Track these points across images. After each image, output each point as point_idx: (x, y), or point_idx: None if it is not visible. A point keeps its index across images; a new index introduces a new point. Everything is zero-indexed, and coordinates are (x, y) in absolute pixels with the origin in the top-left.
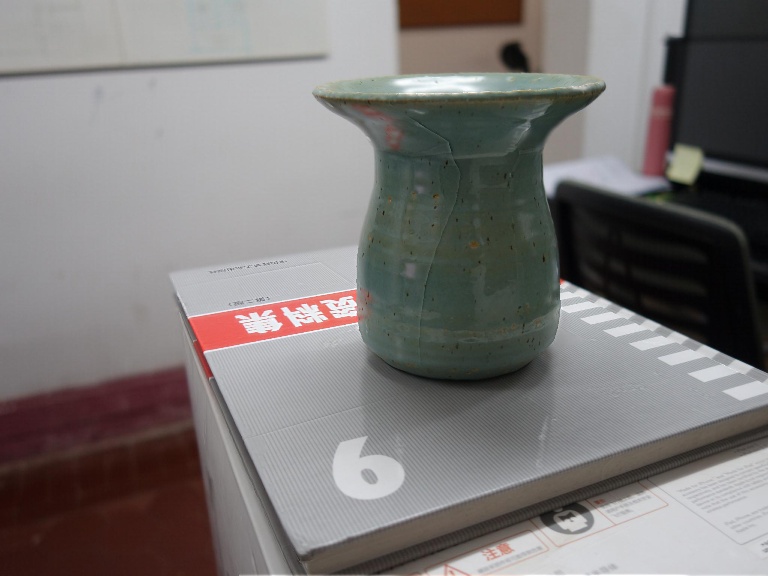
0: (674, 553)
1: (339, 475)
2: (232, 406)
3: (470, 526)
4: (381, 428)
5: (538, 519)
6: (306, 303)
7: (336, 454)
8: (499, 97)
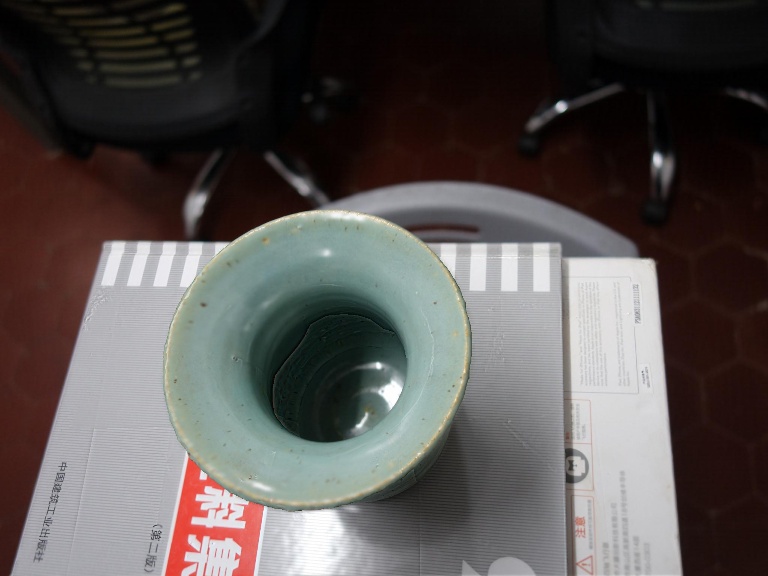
0: (628, 433)
1: None
2: None
3: None
4: (458, 545)
5: None
6: (196, 494)
7: None
8: (463, 394)
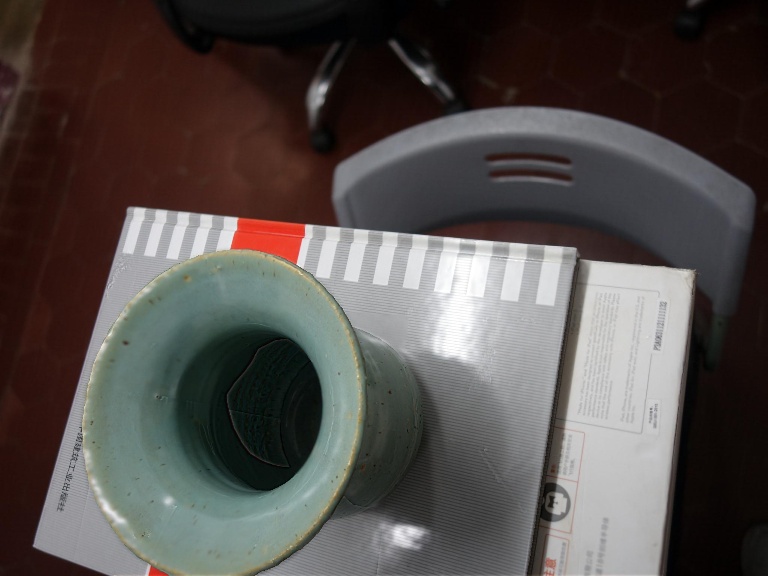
0: (621, 477)
1: None
2: None
3: None
4: (415, 571)
5: (542, 521)
6: None
7: None
8: (346, 487)
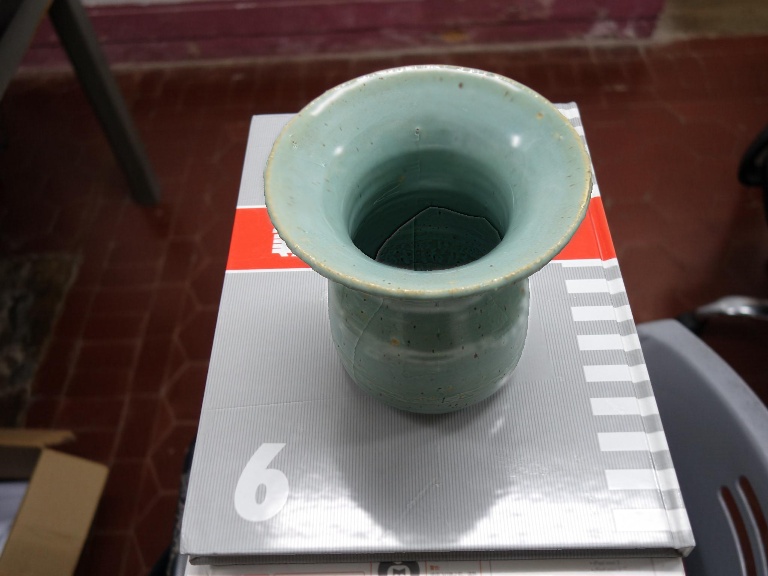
0: None
1: (242, 483)
2: (212, 362)
3: (321, 554)
4: (300, 438)
5: (377, 565)
6: None
7: (252, 457)
8: (382, 294)
